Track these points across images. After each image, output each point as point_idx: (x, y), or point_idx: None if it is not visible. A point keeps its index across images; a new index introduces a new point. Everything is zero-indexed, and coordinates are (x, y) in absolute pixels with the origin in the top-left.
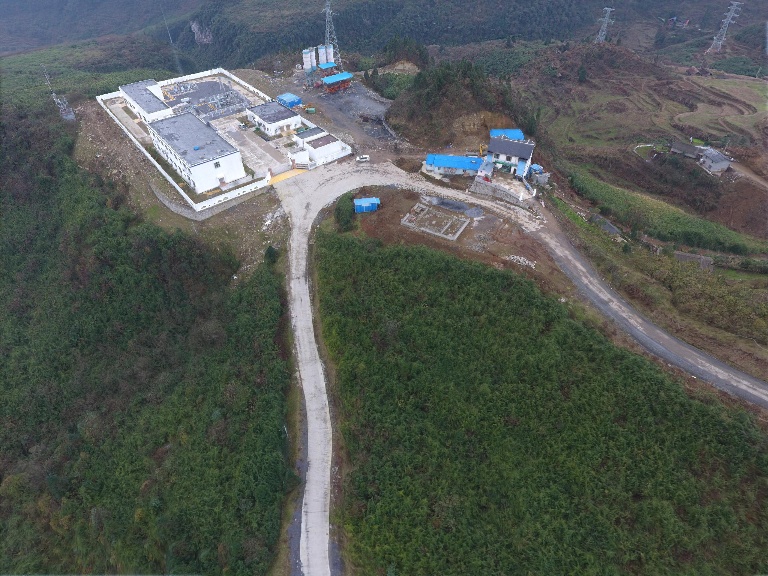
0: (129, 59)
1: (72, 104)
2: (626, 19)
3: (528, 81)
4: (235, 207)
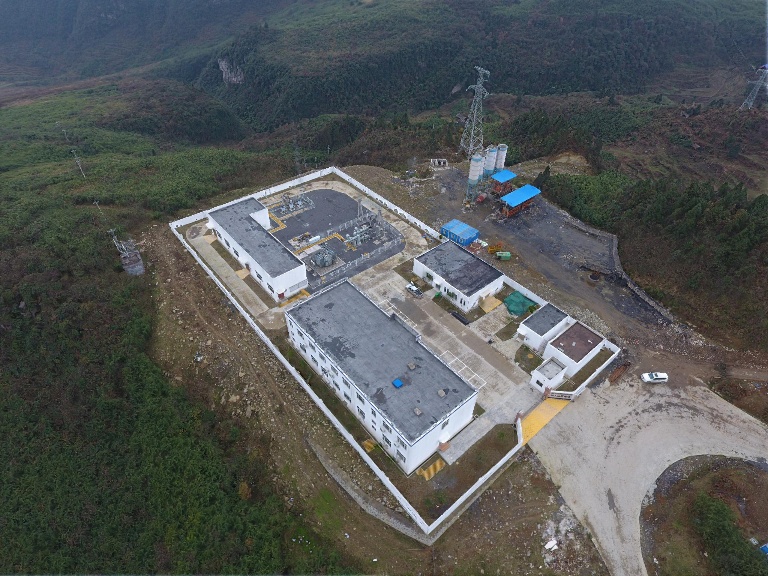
0: (160, 111)
1: (131, 231)
2: (709, 65)
3: (651, 150)
4: (480, 503)
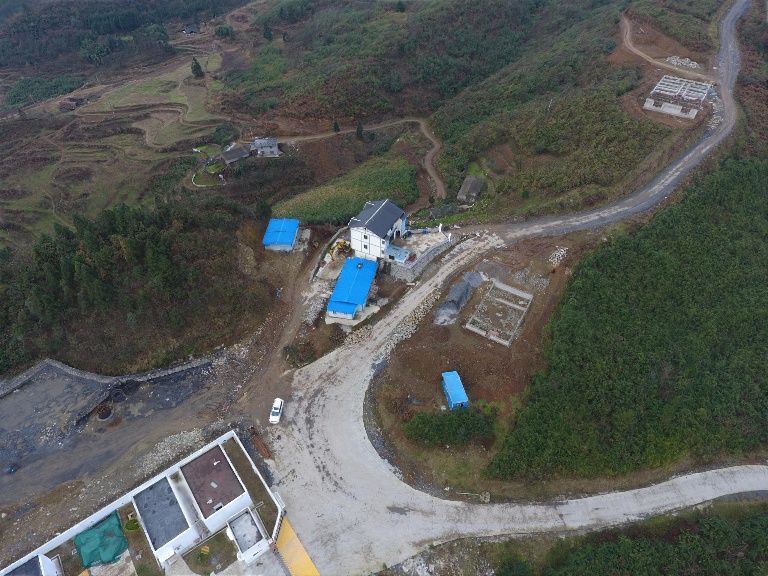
0: None
1: None
2: None
3: None
4: None
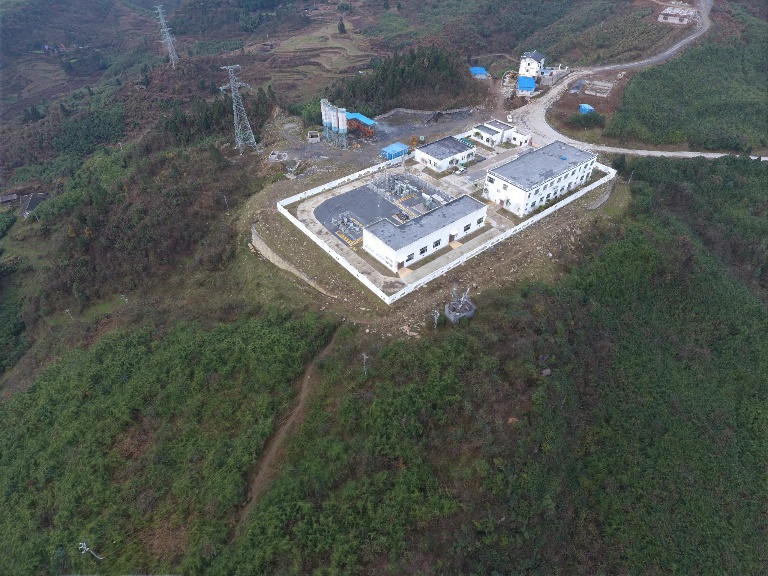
0: None
1: None
2: (6, 64)
3: None
4: None
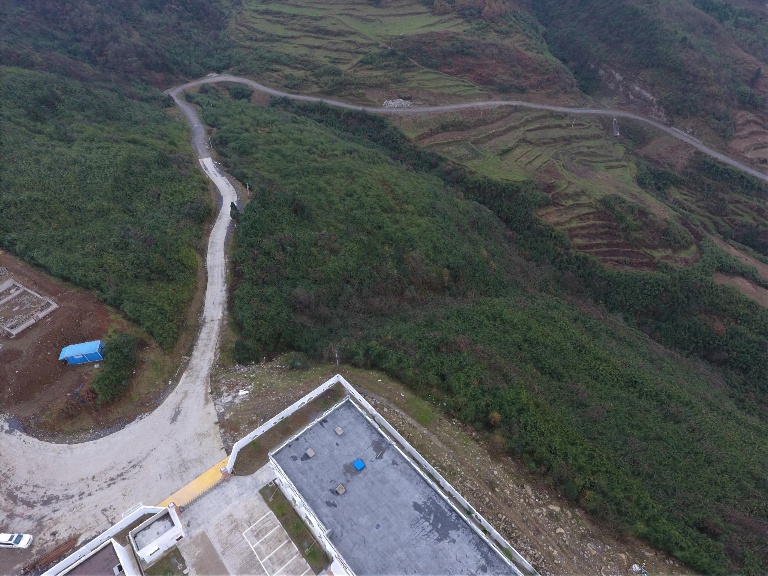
0: None
1: None
2: None
3: None
4: None
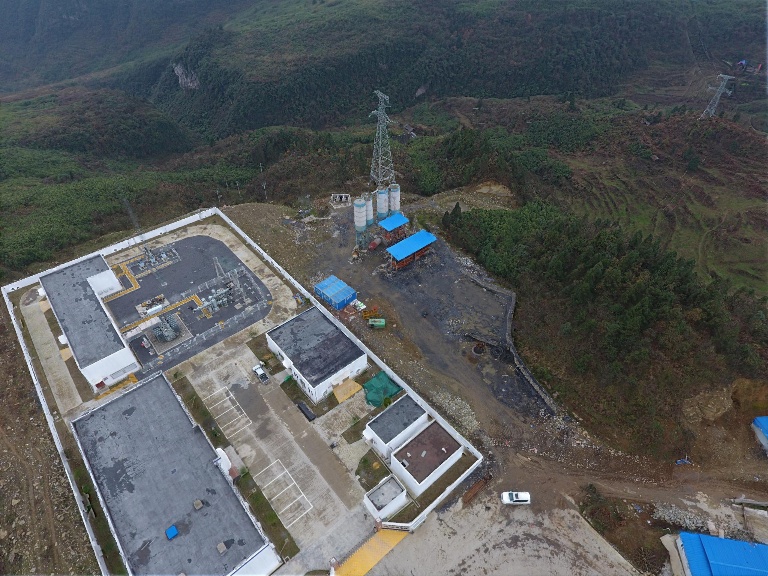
0: (94, 125)
1: None
2: (684, 62)
3: (609, 161)
4: None
